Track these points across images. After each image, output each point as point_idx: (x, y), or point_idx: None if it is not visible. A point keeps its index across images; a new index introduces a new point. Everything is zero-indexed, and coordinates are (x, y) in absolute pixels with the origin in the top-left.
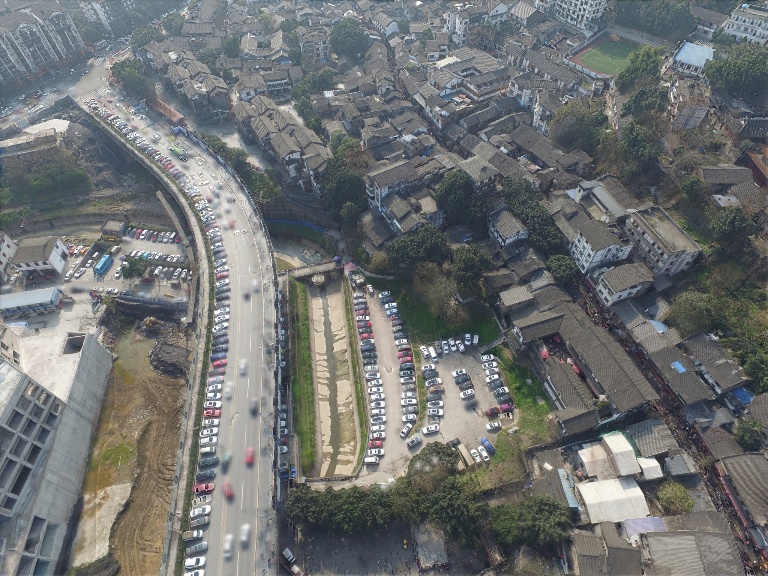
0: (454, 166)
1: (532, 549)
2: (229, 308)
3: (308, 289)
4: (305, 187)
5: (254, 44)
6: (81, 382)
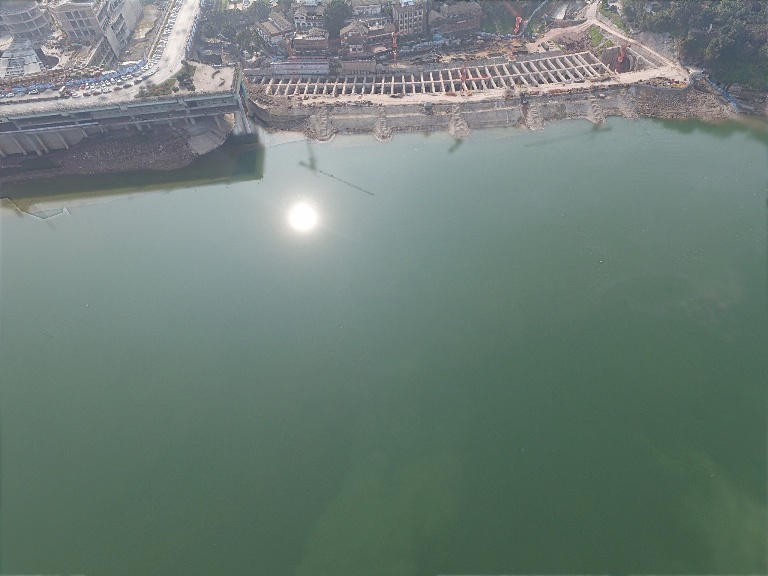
0: None
1: (282, 11)
2: None
3: (228, 1)
4: None
5: None
6: None
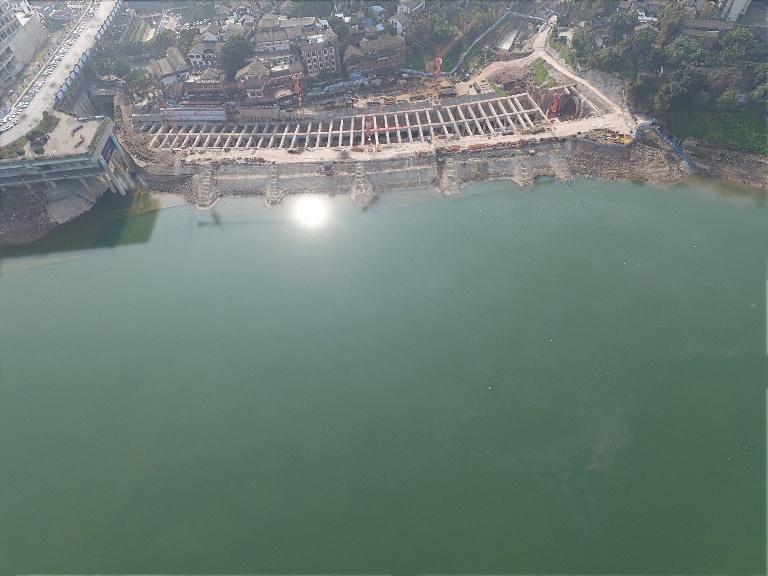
0: None
1: None
2: (98, 8)
3: (149, 25)
4: None
5: None
6: (30, 28)
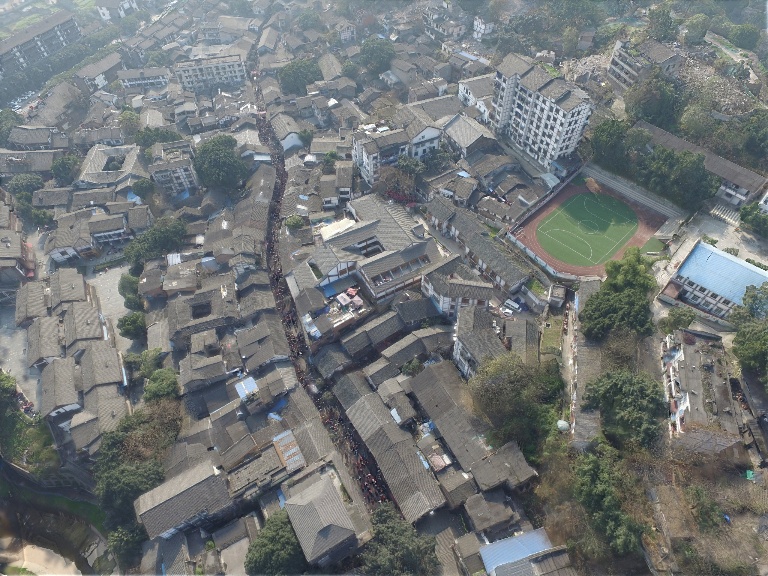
0: (301, 466)
1: None
2: None
3: None
4: (85, 457)
5: (101, 162)
6: None
